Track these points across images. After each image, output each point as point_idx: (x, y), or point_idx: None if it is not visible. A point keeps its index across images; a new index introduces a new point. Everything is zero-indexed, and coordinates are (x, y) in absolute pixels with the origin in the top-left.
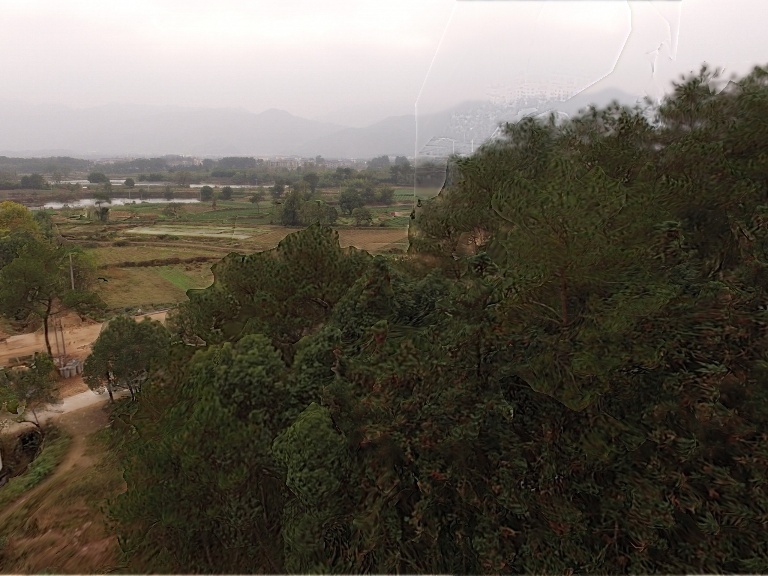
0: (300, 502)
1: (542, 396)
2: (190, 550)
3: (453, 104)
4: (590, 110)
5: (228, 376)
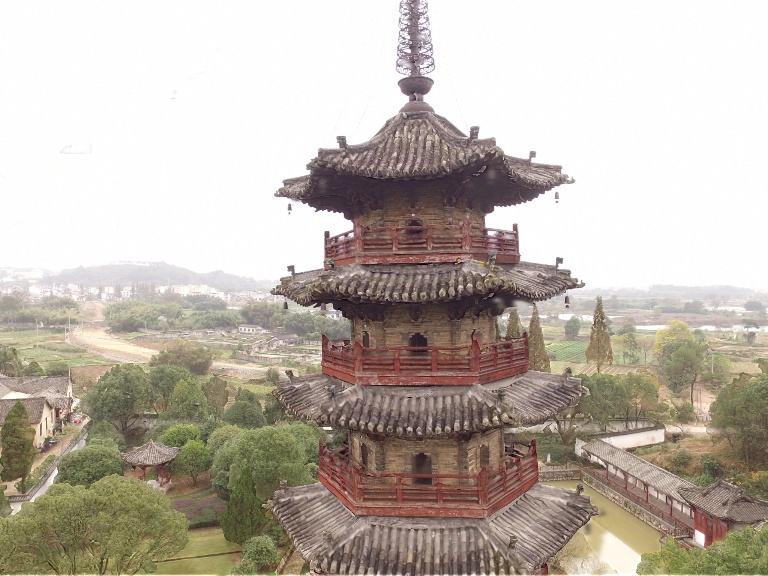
0: None
1: None
2: (740, 458)
3: None
4: None
5: (762, 384)
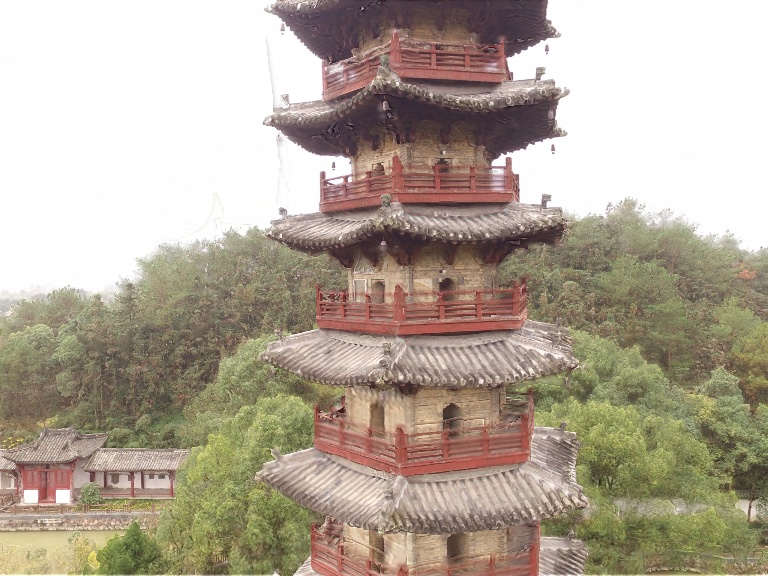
0: (64, 369)
1: (155, 331)
2: (5, 418)
3: (161, 234)
4: (196, 240)
5: (30, 337)
